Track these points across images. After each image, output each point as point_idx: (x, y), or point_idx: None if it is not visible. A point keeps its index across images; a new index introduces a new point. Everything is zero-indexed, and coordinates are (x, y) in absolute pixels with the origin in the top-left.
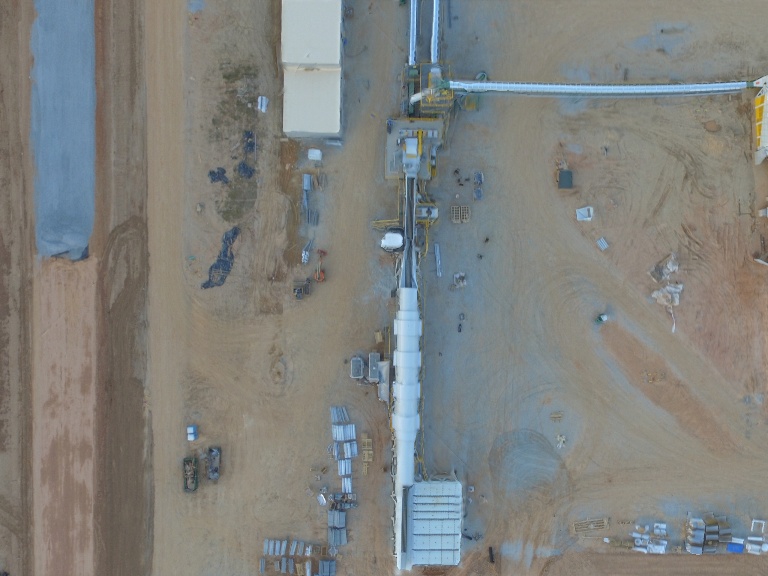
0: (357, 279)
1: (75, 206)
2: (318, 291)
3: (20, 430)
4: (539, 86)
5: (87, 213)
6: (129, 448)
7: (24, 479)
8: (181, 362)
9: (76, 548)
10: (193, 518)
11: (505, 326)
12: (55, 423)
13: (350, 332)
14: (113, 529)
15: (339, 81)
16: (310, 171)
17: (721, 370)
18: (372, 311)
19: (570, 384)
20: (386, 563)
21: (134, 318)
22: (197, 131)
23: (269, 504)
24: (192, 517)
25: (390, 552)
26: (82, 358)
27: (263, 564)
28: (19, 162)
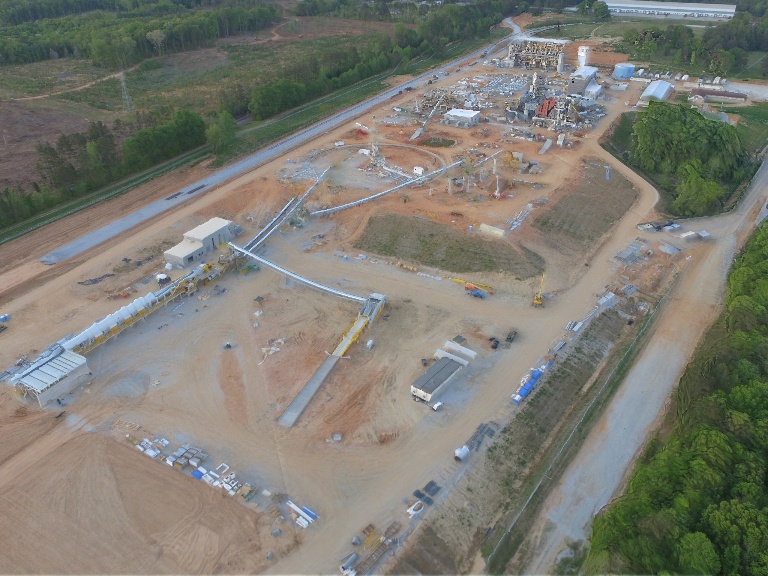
0: None
1: (69, 253)
2: (119, 300)
3: None
4: (268, 261)
5: (70, 255)
6: None
7: None
8: None
9: None
10: None
11: None
12: None
13: None
14: None
15: (199, 248)
16: (162, 271)
17: None
18: None
19: None
20: (7, 397)
21: None
22: (136, 248)
23: None
24: None
25: None
26: (5, 286)
27: None
28: (68, 240)
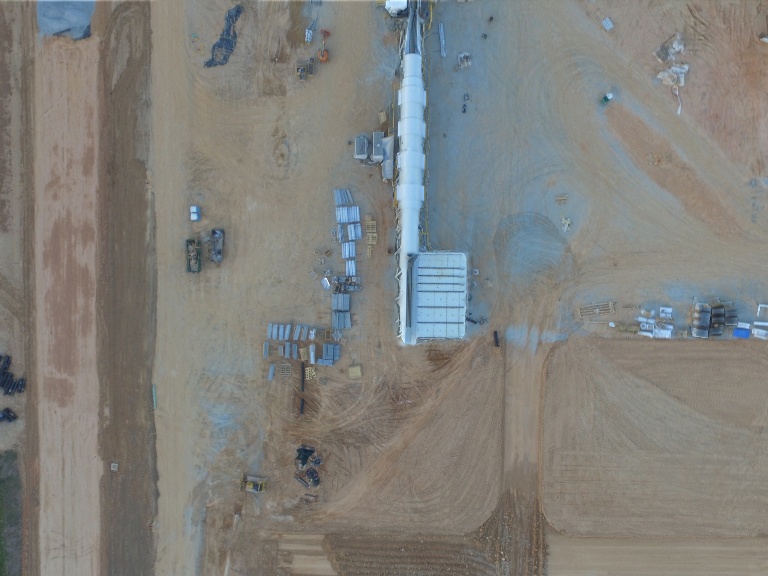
0: (361, 60)
1: None
2: (322, 72)
3: (22, 212)
4: None
5: None
6: (132, 231)
7: (26, 262)
8: (184, 142)
9: (78, 332)
10: (196, 302)
11: (510, 107)
12: (57, 205)
13: (354, 113)
14: (116, 314)
15: None
16: None
17: (727, 153)
18: (376, 92)
19: (575, 166)
20: (390, 348)
21: (136, 98)
22: None
23: (273, 289)
24: (195, 301)
25: (394, 336)
26: (84, 139)
27: (267, 348)
28: None
